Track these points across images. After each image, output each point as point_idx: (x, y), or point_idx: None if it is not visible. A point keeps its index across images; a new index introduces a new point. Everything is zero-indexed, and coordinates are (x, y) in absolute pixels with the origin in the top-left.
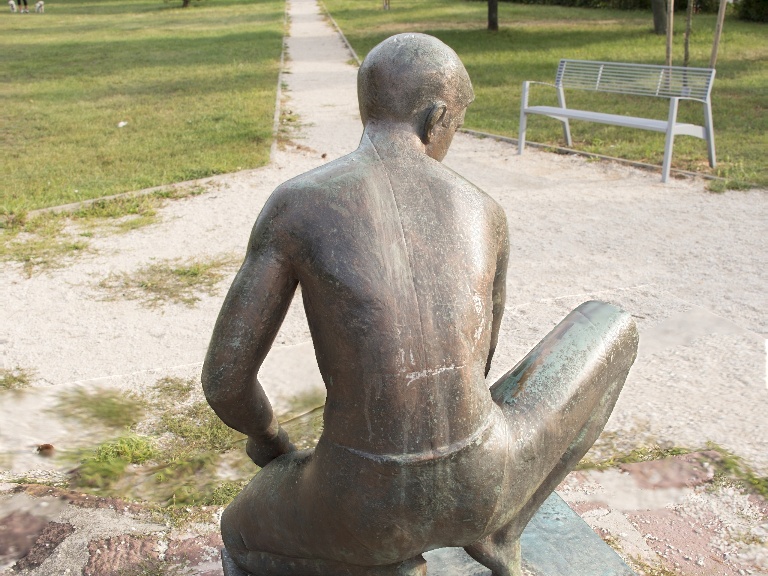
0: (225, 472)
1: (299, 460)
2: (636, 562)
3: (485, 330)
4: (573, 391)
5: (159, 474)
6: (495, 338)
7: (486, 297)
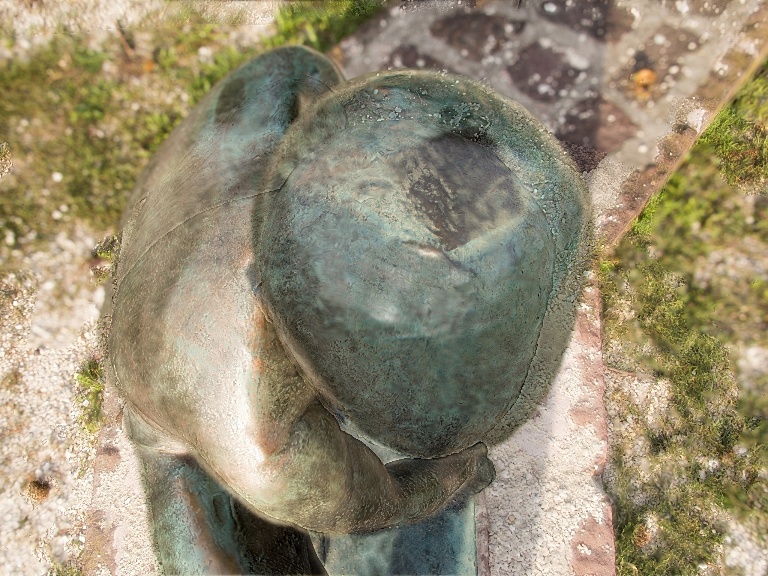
0: (760, 356)
1: None
2: None
3: None
4: None
5: (761, 281)
6: None
7: None
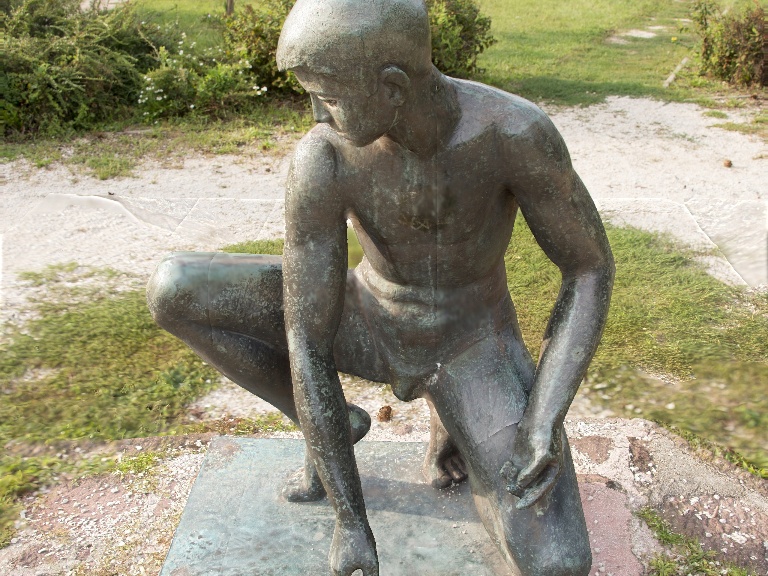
0: None
1: (522, 348)
2: None
3: None
4: None
5: None
6: None
7: None
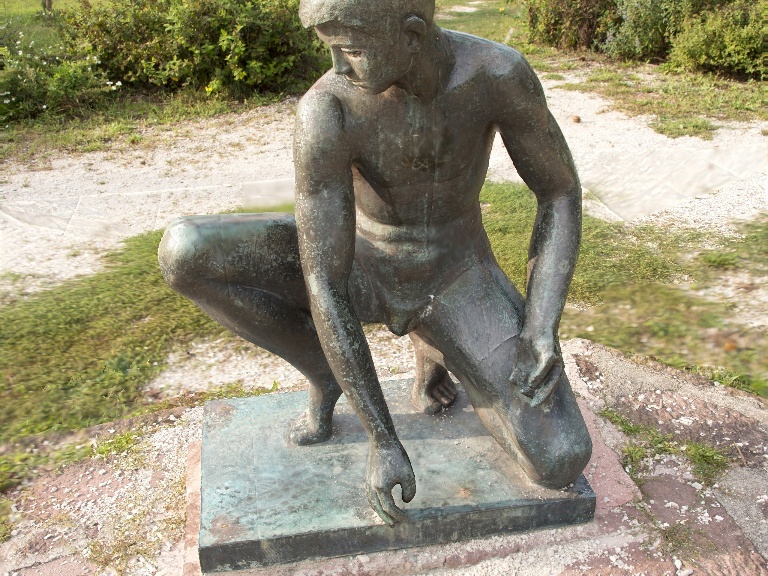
0: None
1: None
2: (126, 574)
3: None
4: None
5: None
6: None
7: None
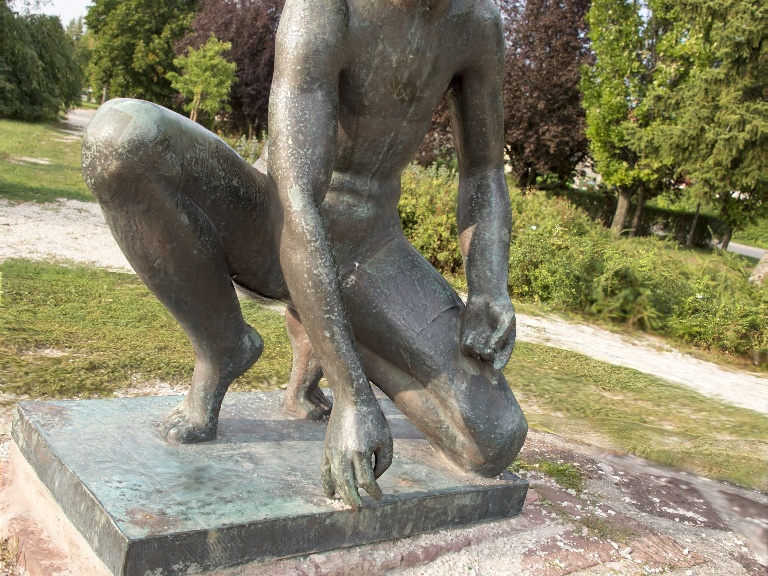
0: None
1: None
2: None
3: None
4: None
5: None
6: None
7: None
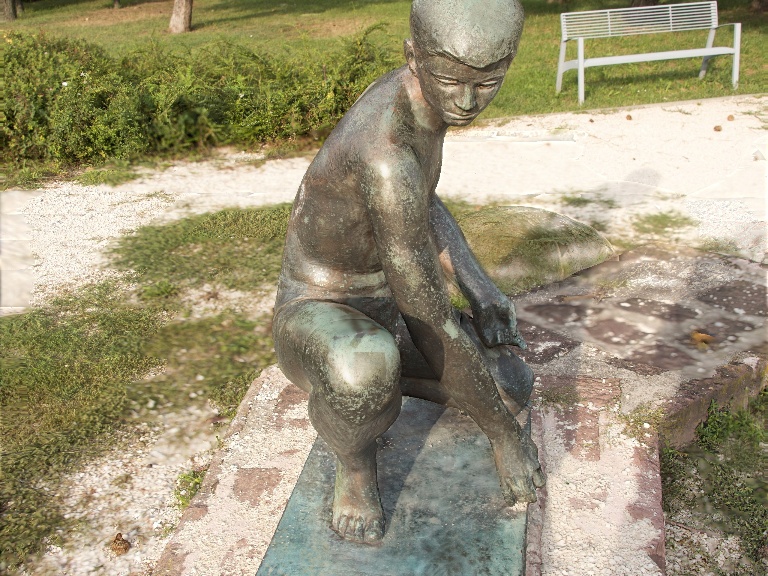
0: None
1: None
2: None
3: (301, 217)
4: (290, 329)
5: None
6: (396, 300)
7: (309, 195)
